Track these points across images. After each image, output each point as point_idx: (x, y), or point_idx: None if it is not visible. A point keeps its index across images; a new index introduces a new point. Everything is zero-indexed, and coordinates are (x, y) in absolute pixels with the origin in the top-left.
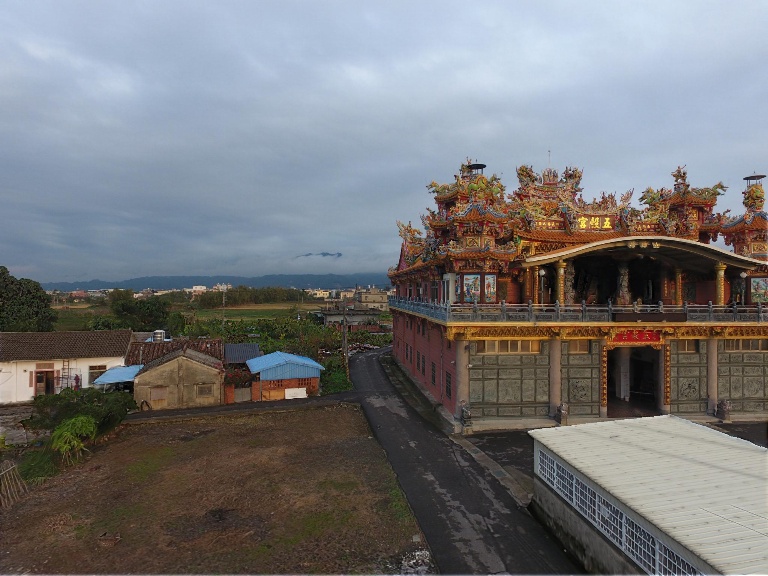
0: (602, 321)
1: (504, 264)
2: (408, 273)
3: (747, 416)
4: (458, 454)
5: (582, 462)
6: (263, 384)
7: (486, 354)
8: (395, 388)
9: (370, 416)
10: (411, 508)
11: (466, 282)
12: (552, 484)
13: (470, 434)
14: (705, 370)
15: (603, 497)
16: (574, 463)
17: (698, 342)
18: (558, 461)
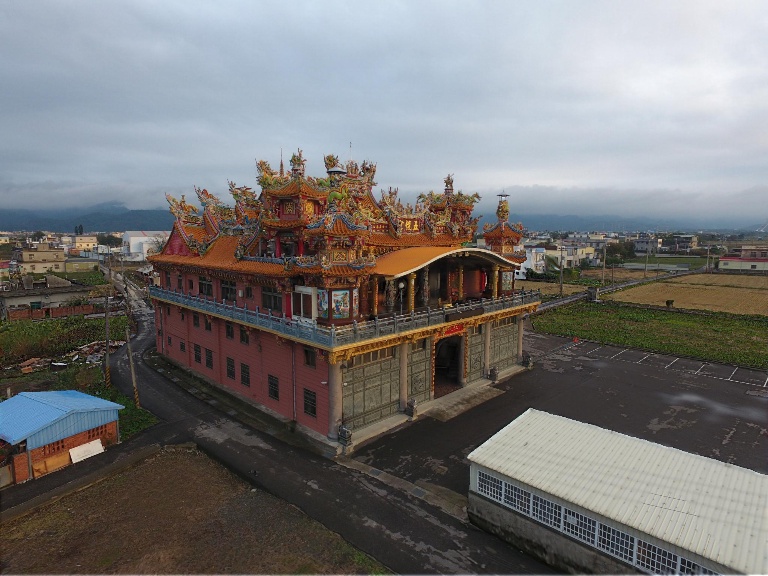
0: (439, 323)
1: (366, 277)
2: (213, 270)
3: (502, 374)
4: (366, 482)
5: (540, 482)
6: (32, 454)
7: (355, 369)
8: (212, 406)
9: (228, 460)
10: (395, 572)
11: (335, 298)
12: (499, 500)
13: (352, 452)
14: (483, 346)
15: (573, 510)
16: (538, 486)
17: (481, 326)
18: (508, 481)
